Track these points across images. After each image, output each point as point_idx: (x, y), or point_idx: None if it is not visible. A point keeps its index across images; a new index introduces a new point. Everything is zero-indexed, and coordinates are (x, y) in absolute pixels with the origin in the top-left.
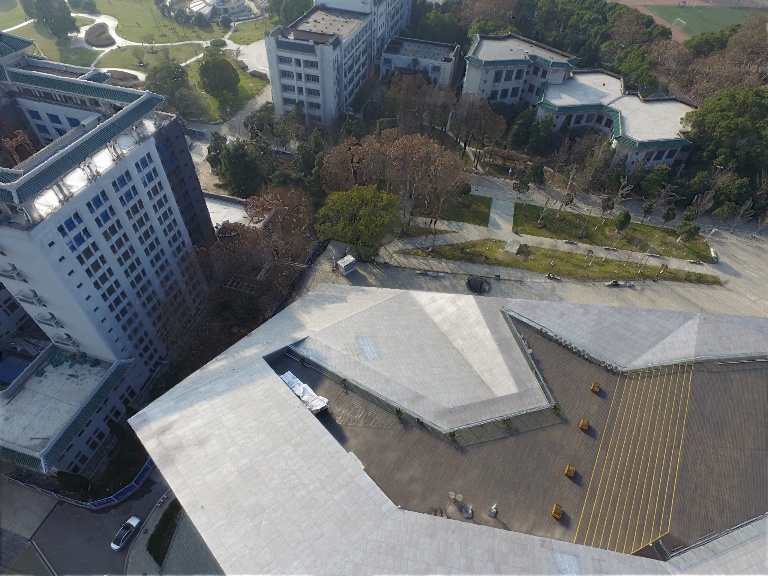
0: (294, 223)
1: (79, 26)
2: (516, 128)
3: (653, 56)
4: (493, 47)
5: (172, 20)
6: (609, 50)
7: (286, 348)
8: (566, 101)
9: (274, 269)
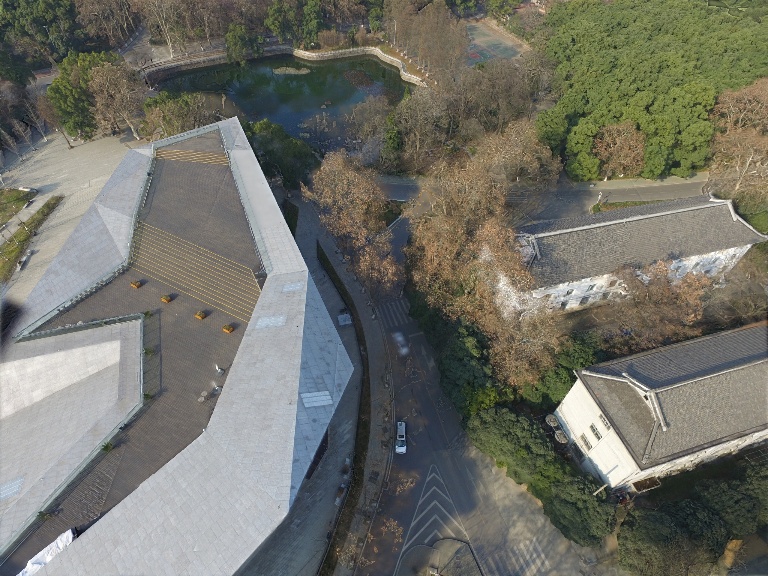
0: None
1: None
2: None
3: None
4: None
5: None
6: None
7: None
8: None
9: None
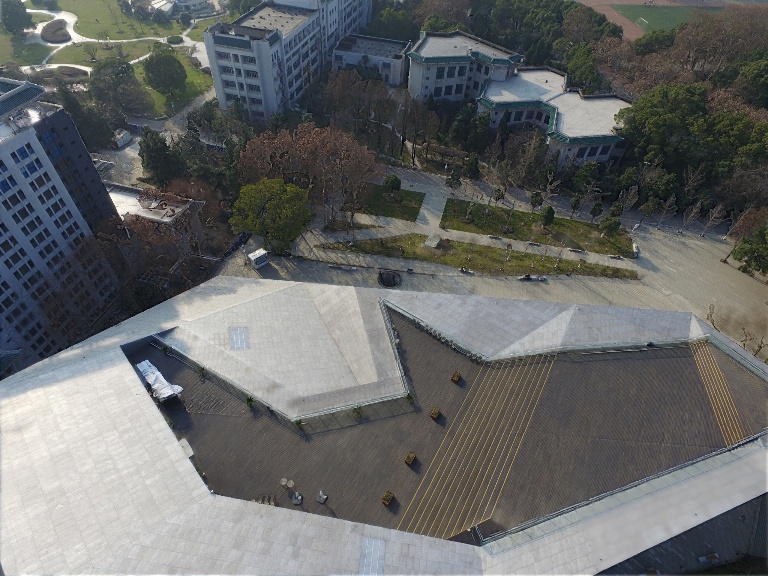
0: (221, 217)
1: (37, 22)
2: (456, 124)
3: (597, 53)
4: (438, 44)
5: (132, 17)
6: (559, 48)
7: (151, 337)
8: (506, 98)
9: (190, 263)
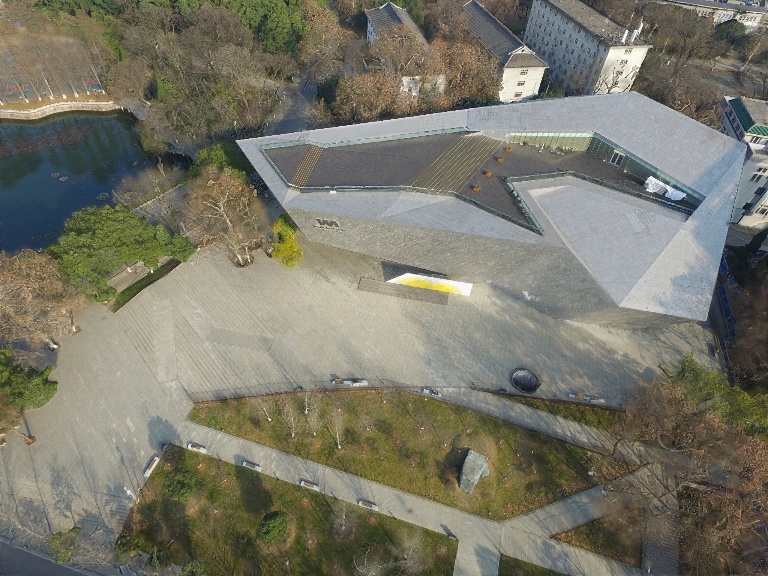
0: None
1: None
2: None
3: None
4: None
5: None
6: None
7: None
8: None
9: None
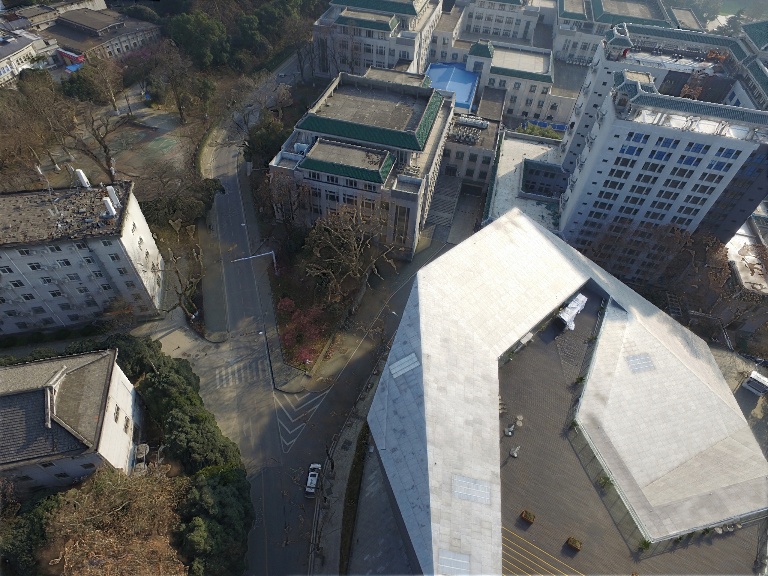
0: None
1: None
2: None
3: None
4: None
5: None
6: None
7: (608, 296)
8: None
9: (712, 327)
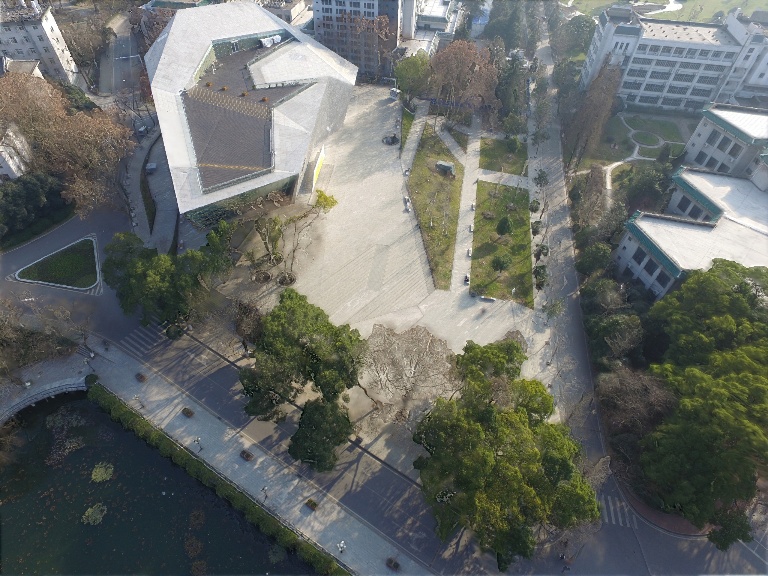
0: None
1: (648, 1)
2: None
3: None
4: None
5: None
6: None
7: None
8: (709, 188)
9: None
